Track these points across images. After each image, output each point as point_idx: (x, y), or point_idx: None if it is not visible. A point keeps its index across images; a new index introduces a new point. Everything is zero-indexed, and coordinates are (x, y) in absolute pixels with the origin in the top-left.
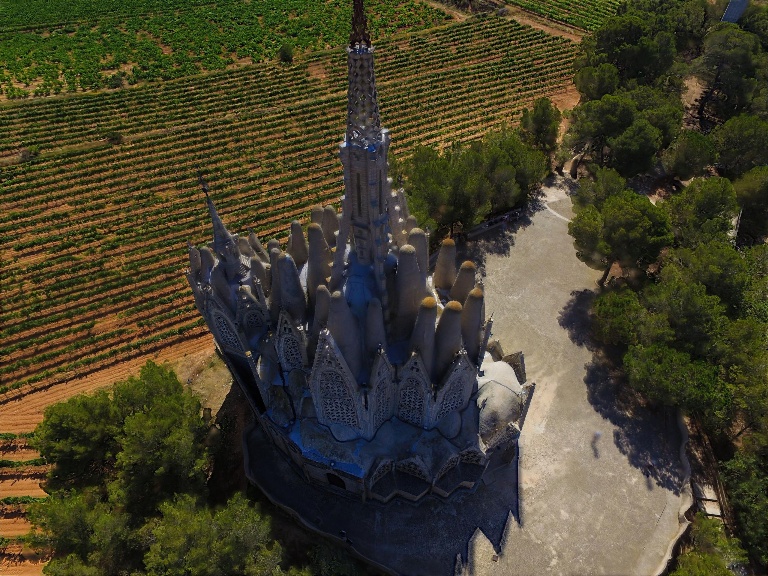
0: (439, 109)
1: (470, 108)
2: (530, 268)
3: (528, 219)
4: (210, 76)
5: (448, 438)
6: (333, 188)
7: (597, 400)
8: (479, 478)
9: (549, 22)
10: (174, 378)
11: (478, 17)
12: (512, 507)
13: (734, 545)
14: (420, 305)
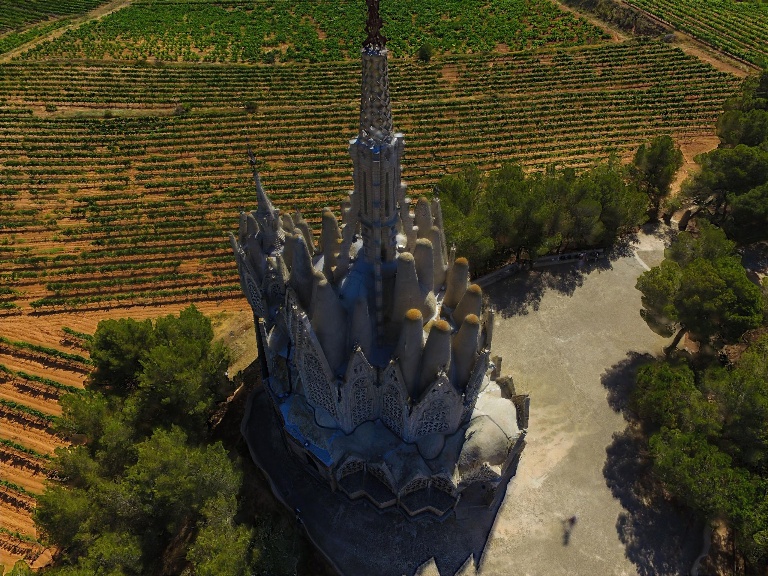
0: (560, 130)
1: (593, 135)
2: (590, 314)
3: (608, 263)
4: (350, 64)
5: (424, 458)
6: (423, 189)
7: (613, 475)
8: (446, 508)
9: (722, 55)
10: (208, 325)
11: (638, 40)
12: (475, 551)
13: None
14: (405, 315)
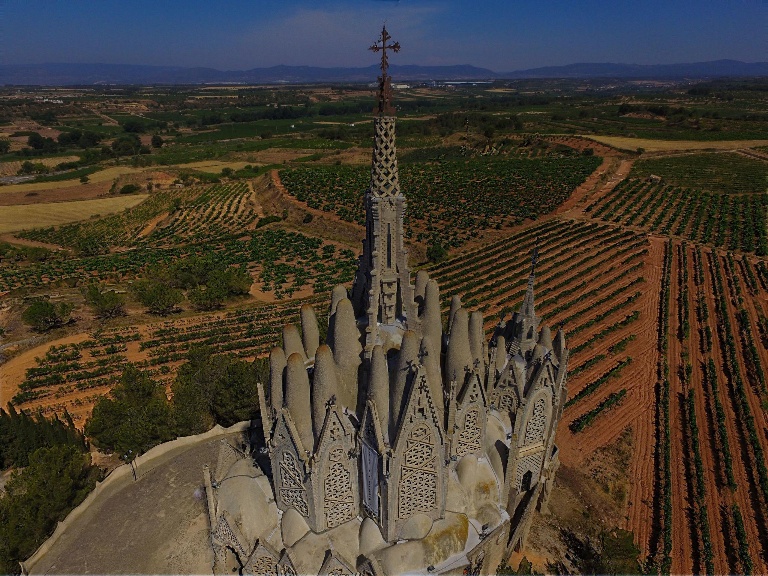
0: None
1: None
2: None
3: None
4: None
5: None
6: None
7: None
8: None
9: None
10: None
11: None
12: None
13: None
14: None
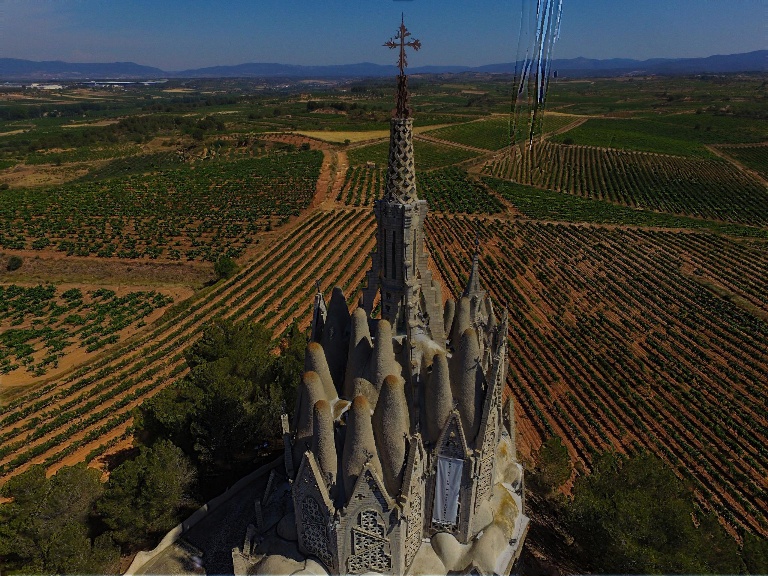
0: None
1: None
2: None
3: None
4: None
5: None
6: None
7: None
8: None
9: None
10: None
11: None
12: None
13: None
14: None
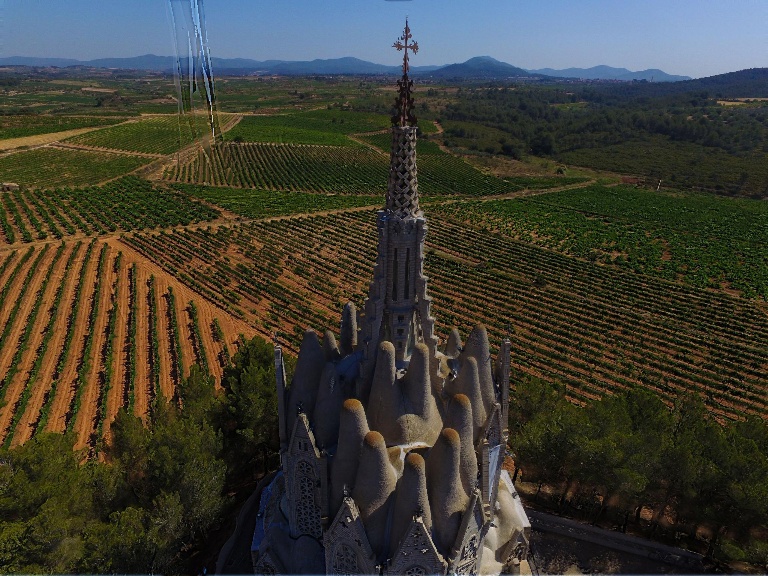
0: None
1: None
2: None
3: None
4: (674, 285)
5: None
6: None
7: None
8: None
9: None
10: None
11: None
12: None
13: None
14: None
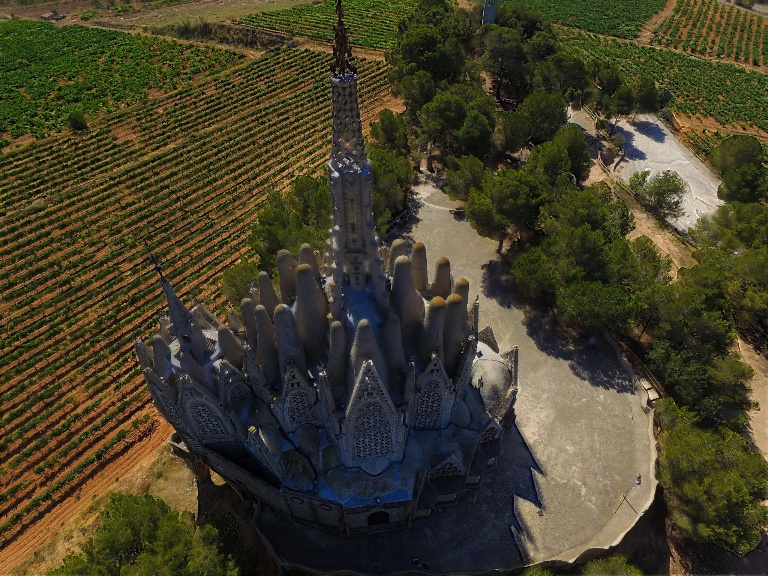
0: (277, 142)
1: (307, 135)
2: None
3: (415, 217)
4: None
5: (465, 427)
6: (205, 245)
7: (545, 346)
8: (500, 451)
9: None
10: (151, 500)
11: (272, 51)
12: (531, 463)
13: (685, 412)
14: (430, 307)
